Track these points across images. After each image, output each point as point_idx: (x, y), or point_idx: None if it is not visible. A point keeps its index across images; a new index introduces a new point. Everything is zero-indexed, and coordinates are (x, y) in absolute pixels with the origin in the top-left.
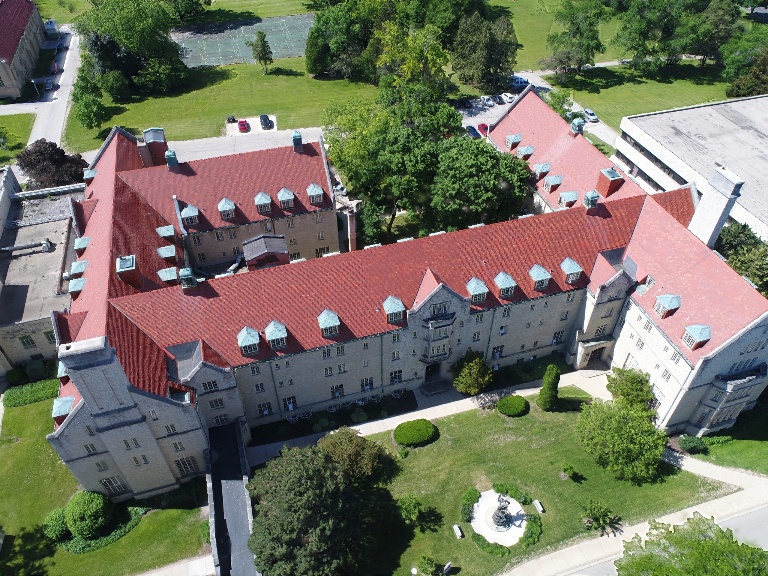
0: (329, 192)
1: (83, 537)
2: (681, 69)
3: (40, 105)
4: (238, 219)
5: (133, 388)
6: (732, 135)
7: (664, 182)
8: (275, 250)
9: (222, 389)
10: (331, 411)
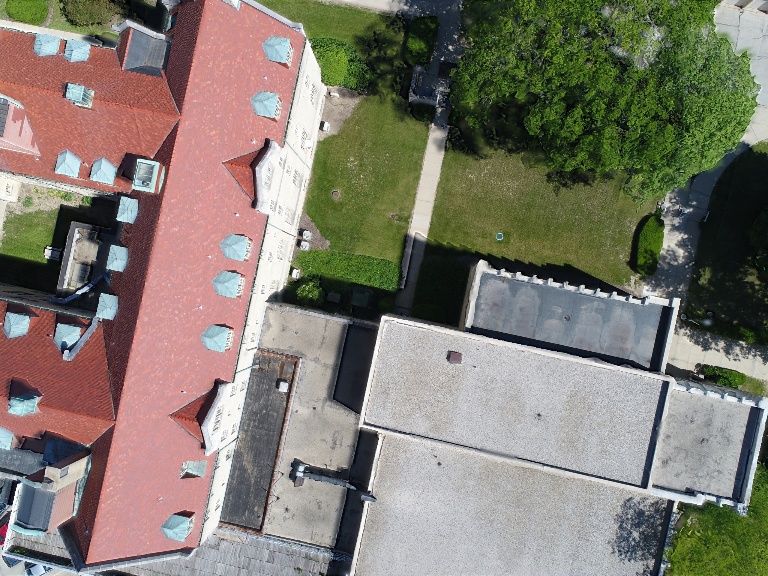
0: None
1: None
2: None
3: None
4: (19, 311)
5: None
6: None
7: None
8: None
9: None
10: None
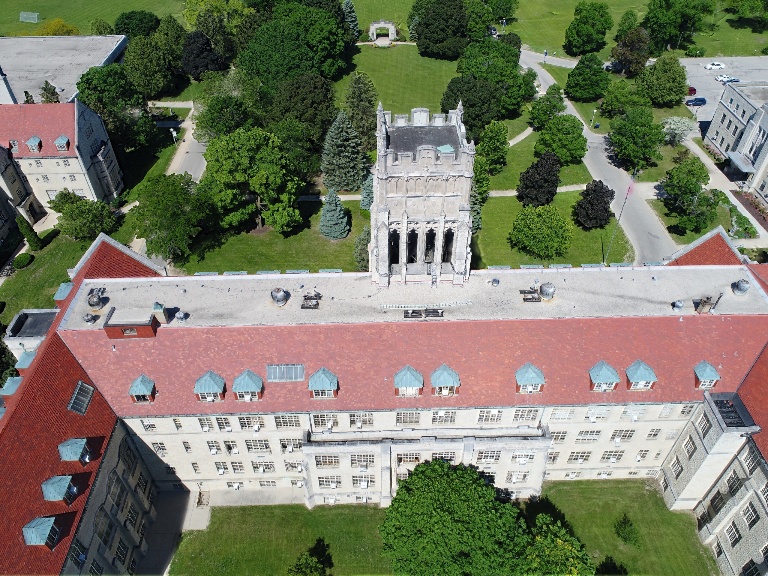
0: None
1: None
2: None
3: None
4: None
5: None
6: None
7: None
8: None
9: None
10: None
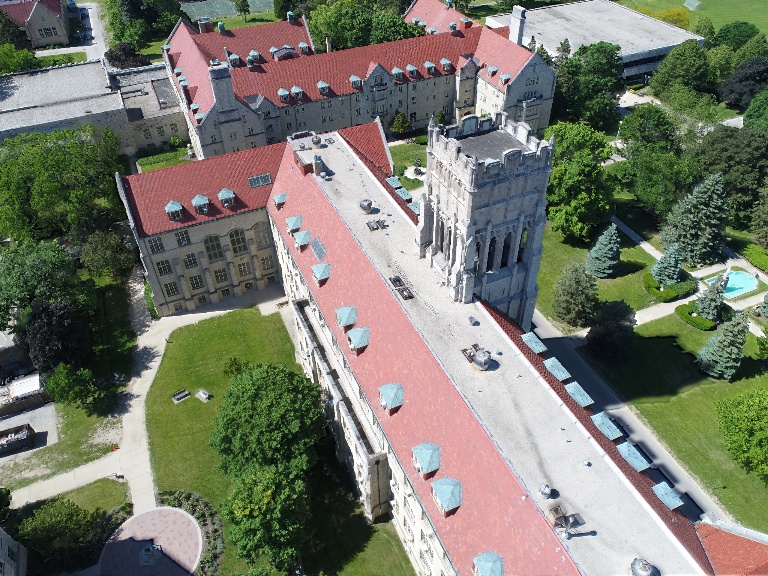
0: (311, 47)
1: None
2: (537, 4)
3: (85, 47)
4: (261, 61)
5: None
6: (551, 21)
7: None
8: (292, 52)
9: (273, 117)
10: None
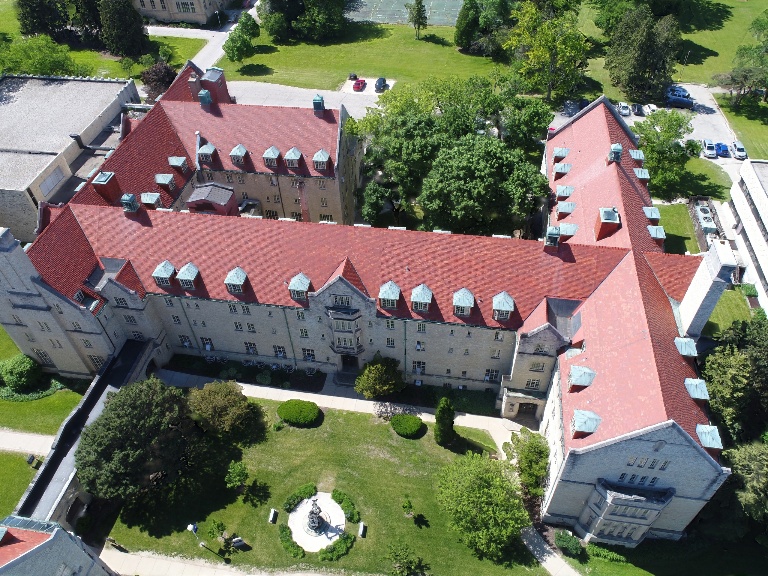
0: (335, 162)
1: (10, 388)
2: None
3: (216, 34)
4: (246, 166)
5: (36, 279)
6: None
7: (759, 249)
8: (214, 199)
9: (131, 308)
10: (244, 364)
